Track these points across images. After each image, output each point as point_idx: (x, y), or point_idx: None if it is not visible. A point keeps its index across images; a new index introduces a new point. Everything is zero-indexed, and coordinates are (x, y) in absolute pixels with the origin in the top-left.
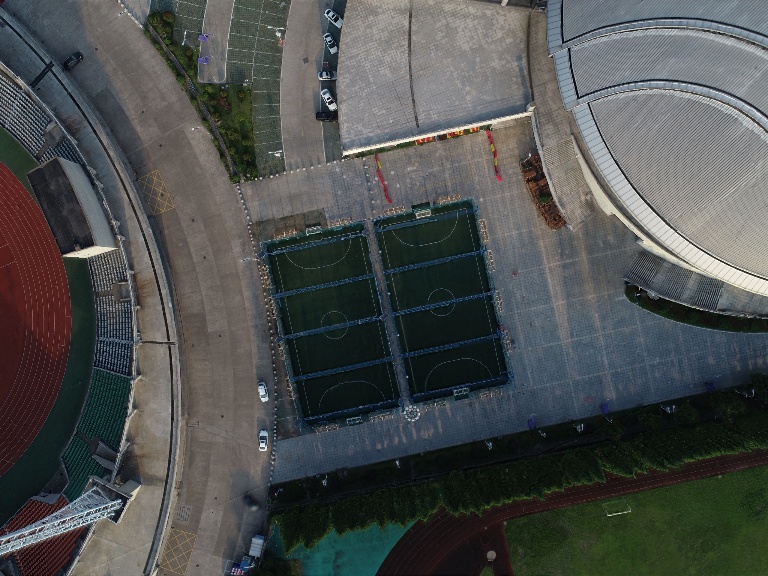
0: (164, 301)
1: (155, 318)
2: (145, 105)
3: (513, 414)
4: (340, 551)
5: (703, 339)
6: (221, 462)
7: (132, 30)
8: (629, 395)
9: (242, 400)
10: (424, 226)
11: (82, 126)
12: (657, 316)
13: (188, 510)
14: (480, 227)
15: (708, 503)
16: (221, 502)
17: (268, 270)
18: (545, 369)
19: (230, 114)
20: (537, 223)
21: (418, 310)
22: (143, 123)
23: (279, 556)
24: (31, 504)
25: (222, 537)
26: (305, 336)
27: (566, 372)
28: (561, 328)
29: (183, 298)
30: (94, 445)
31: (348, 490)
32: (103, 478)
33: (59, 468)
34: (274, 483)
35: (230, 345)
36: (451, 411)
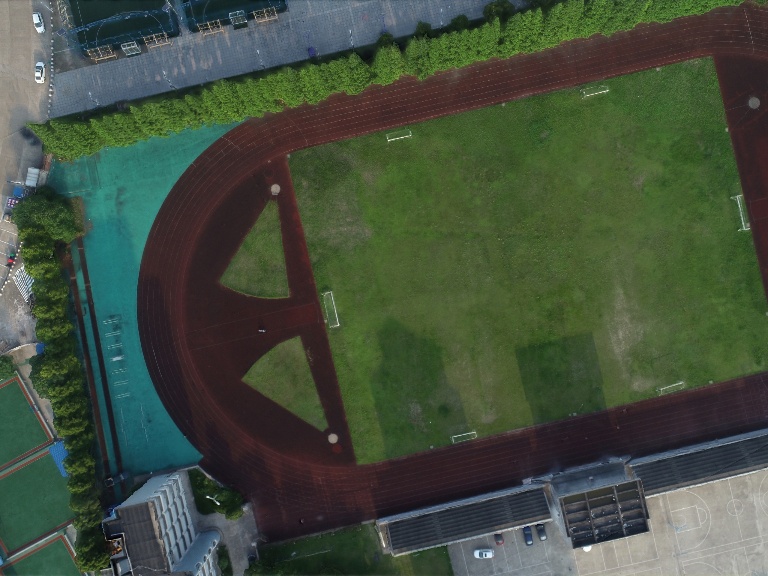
0: None
1: None
2: None
3: (293, 43)
4: (122, 187)
5: None
6: None
7: None
8: (409, 21)
9: (18, 33)
10: None
11: None
12: None
13: None
14: None
15: (492, 131)
16: None
17: None
18: None
19: None
20: None
21: None
22: None
23: (60, 192)
24: None
25: (1, 173)
26: None
27: None
28: None
29: None
30: None
31: None
32: None
33: None
34: (53, 117)
35: None
36: (230, 40)
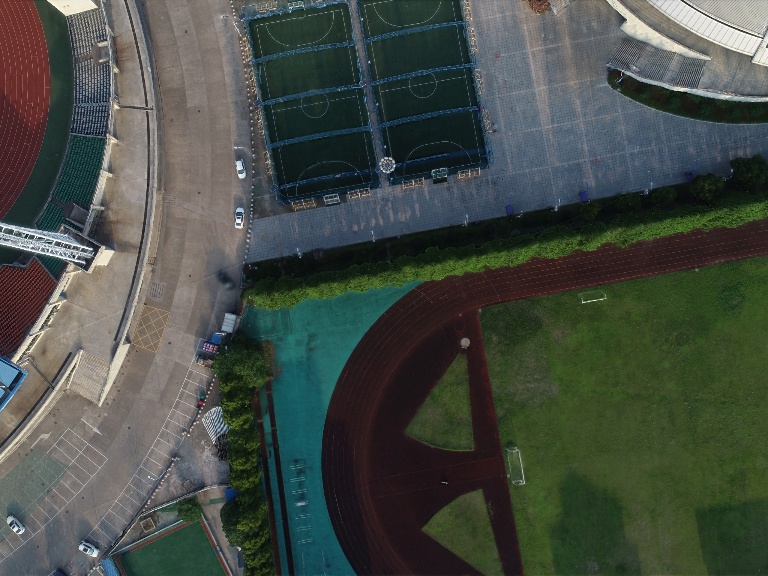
0: (143, 66)
1: (134, 83)
2: None
3: (491, 199)
4: (313, 334)
5: (684, 129)
6: (196, 239)
7: None
8: (608, 183)
9: (219, 177)
10: (408, 6)
11: None
12: (639, 104)
13: (162, 287)
14: (463, 3)
15: (684, 296)
16: (195, 279)
17: (249, 40)
18: (525, 155)
19: None
20: (521, 7)
21: (398, 78)
22: None
23: (252, 336)
24: (4, 270)
25: (195, 315)
26: (285, 114)
27: (546, 158)
28: (542, 114)
29: (163, 72)
30: (68, 209)
31: (323, 271)
32: None
33: None
34: (249, 262)
35: (209, 121)
36: (429, 194)
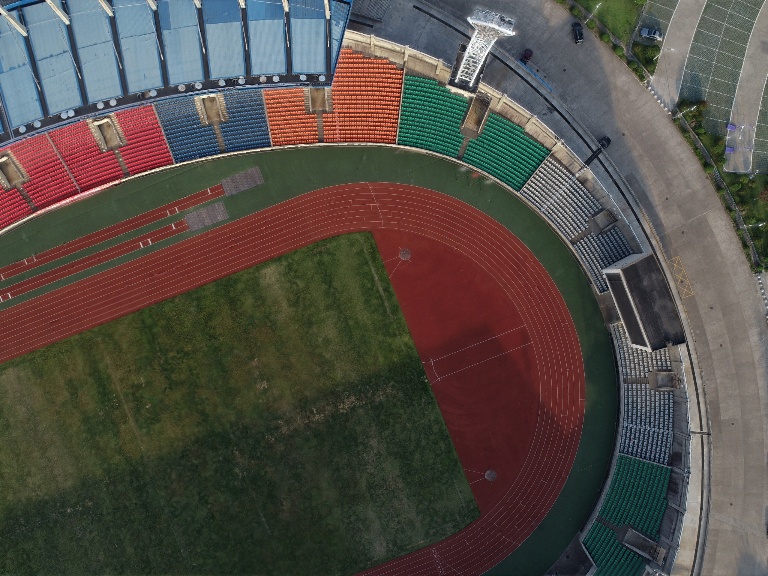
0: (699, 391)
1: None
2: (669, 192)
3: None
4: None
5: None
6: (728, 550)
7: (660, 117)
8: None
9: (752, 489)
10: None
11: (626, 214)
12: None
13: None
14: None
15: None
16: None
17: None
18: None
19: (756, 204)
20: None
21: None
22: (666, 210)
23: None
24: None
25: None
26: None
27: None
28: None
29: None
30: (622, 532)
31: None
32: (651, 569)
33: (565, 550)
34: None
35: (742, 434)
36: None
